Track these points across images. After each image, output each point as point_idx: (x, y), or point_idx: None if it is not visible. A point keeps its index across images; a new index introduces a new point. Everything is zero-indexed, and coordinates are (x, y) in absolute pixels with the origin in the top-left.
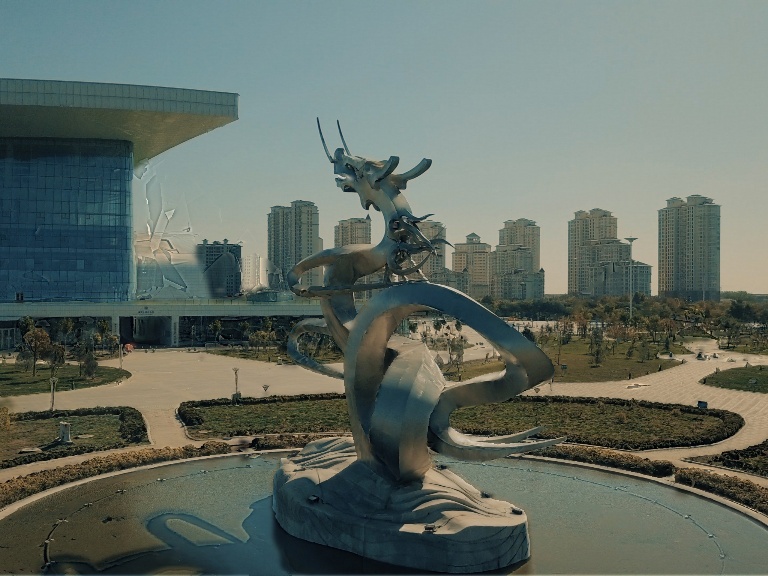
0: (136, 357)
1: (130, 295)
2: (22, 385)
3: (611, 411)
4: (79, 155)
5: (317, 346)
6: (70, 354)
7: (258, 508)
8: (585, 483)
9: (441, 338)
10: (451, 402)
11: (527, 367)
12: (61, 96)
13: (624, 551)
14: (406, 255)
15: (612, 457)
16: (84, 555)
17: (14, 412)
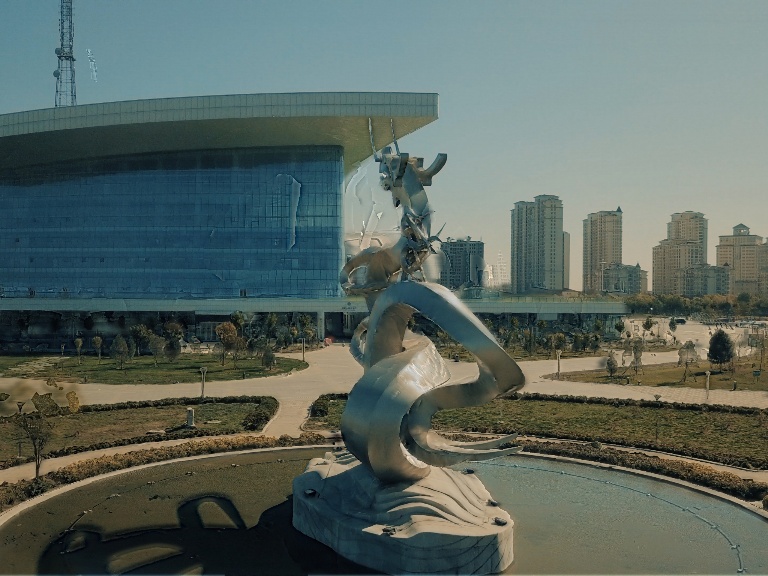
0: (330, 351)
1: (340, 292)
2: None
3: None
4: (295, 161)
5: (504, 344)
6: (272, 346)
7: None
8: (656, 500)
9: (657, 338)
10: (433, 404)
11: (494, 370)
12: (273, 107)
13: None
14: (414, 253)
15: (705, 474)
16: (105, 526)
17: (170, 397)
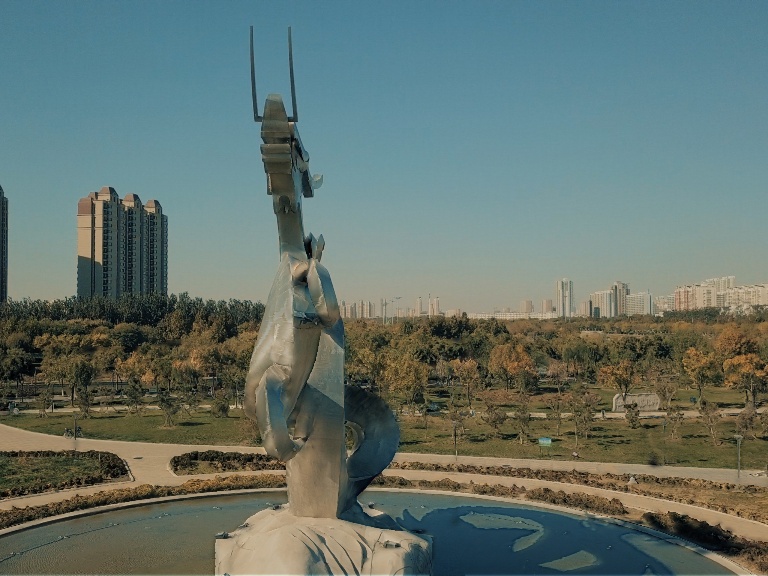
0: None
1: None
2: None
3: None
4: None
5: None
6: None
7: None
8: None
9: None
10: None
11: None
12: None
13: (204, 530)
14: None
15: None
16: None
17: None
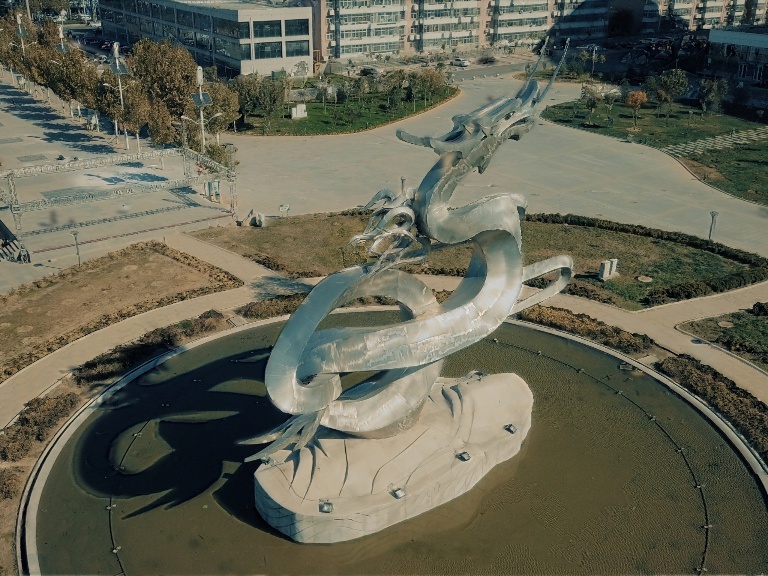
0: None
1: None
2: None
3: None
4: None
5: None
6: None
7: None
8: None
9: None
10: None
11: None
12: None
13: None
14: None
15: None
16: None
17: (682, 232)
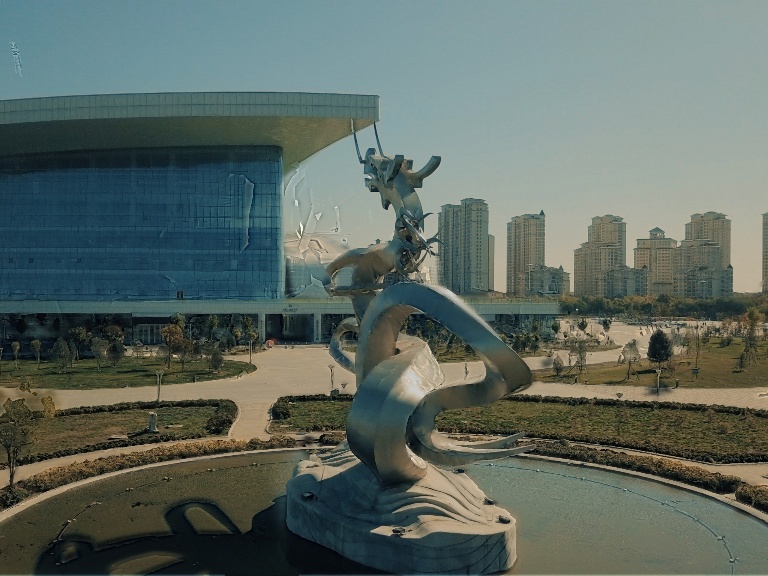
0: (274, 353)
1: (279, 293)
2: (153, 377)
3: (719, 420)
4: (233, 161)
5: (447, 345)
6: None
7: (280, 502)
8: (634, 495)
9: (590, 338)
10: (436, 404)
11: (503, 370)
12: (213, 106)
13: (621, 570)
14: (410, 254)
15: (676, 469)
16: (93, 535)
17: (125, 401)
